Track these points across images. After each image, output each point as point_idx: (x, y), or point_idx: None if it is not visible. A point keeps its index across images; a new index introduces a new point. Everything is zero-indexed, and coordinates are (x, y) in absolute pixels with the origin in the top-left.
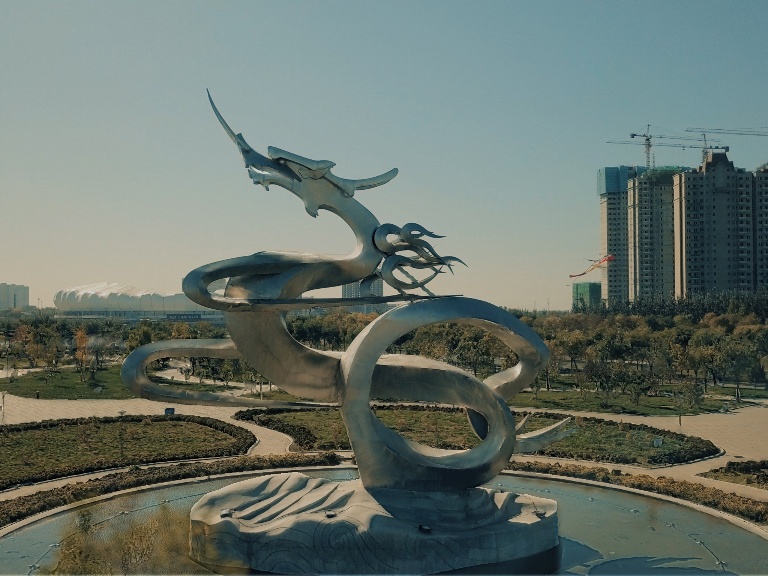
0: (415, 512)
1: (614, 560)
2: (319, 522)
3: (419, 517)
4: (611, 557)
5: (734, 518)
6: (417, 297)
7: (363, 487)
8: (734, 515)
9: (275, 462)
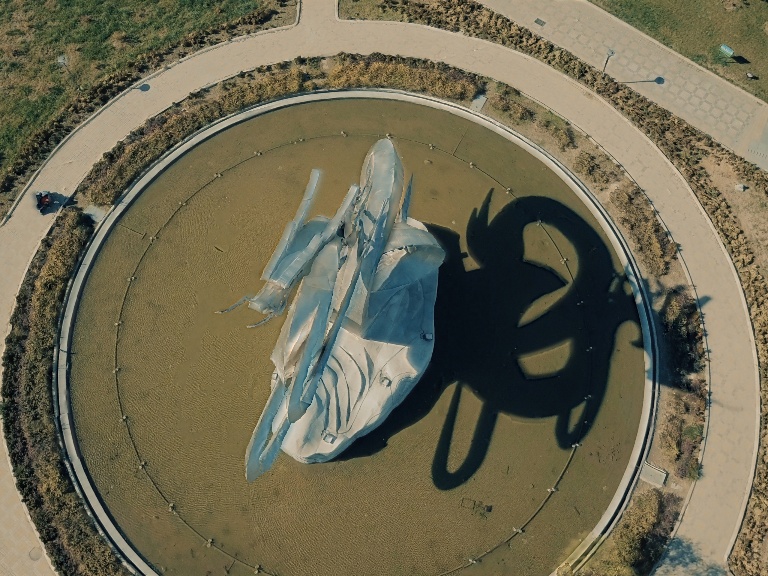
0: (398, 324)
1: (468, 234)
2: (392, 395)
3: (403, 325)
4: (461, 230)
5: (452, 108)
6: (370, 233)
7: (363, 339)
8: (444, 100)
9: (65, 277)
